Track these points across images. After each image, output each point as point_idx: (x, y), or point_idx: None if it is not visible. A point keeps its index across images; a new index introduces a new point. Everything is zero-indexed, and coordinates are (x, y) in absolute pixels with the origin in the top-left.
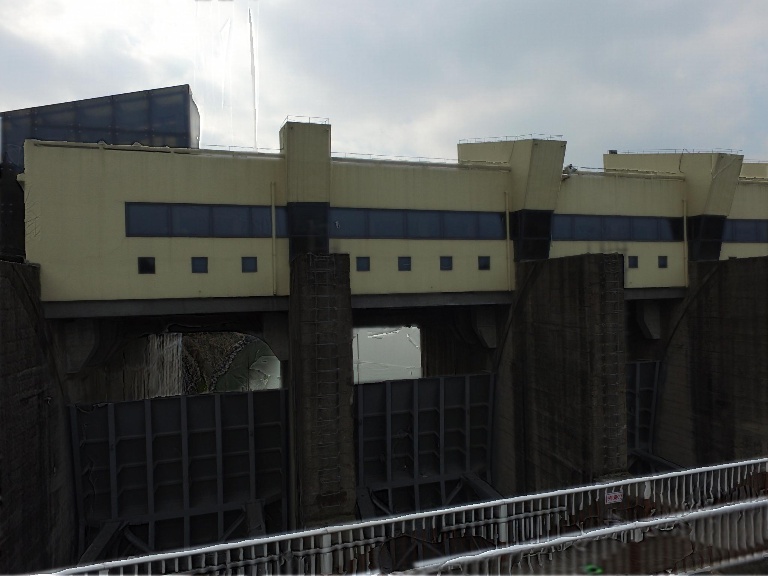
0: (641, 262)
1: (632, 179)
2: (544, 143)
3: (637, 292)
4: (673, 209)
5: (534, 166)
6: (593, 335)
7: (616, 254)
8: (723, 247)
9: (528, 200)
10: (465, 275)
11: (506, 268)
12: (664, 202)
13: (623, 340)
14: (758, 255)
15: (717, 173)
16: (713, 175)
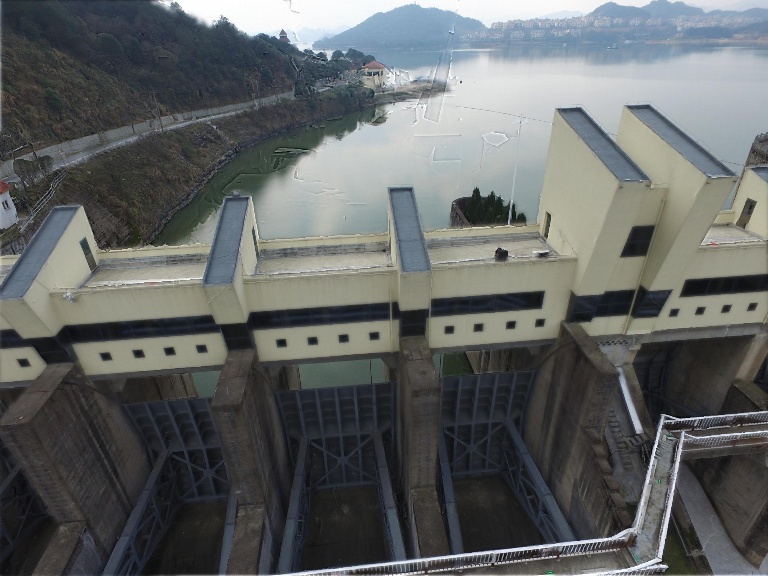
0: (178, 351)
1: (151, 291)
2: (2, 303)
3: (184, 369)
4: (205, 309)
5: (7, 316)
6: (22, 465)
7: (17, 426)
8: (269, 333)
9: (22, 334)
10: (11, 371)
11: (46, 365)
12: (193, 305)
13: (51, 466)
14: (312, 336)
15: (210, 300)
16: (206, 301)
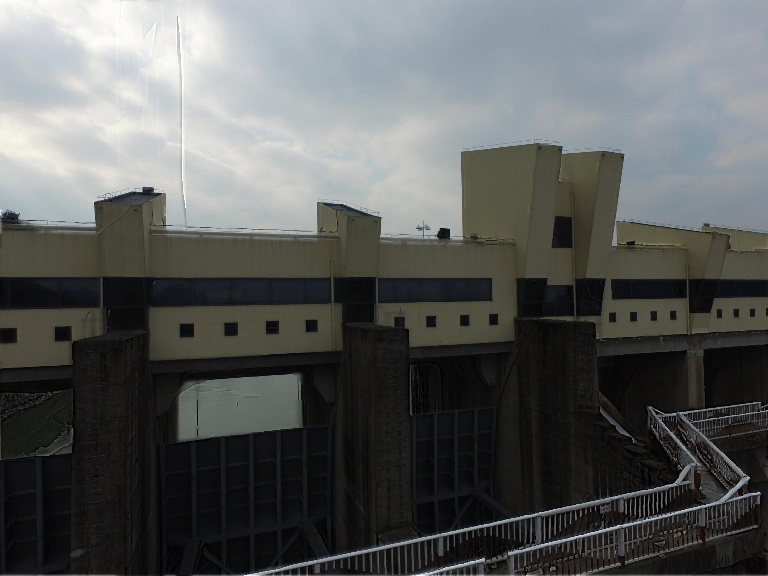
0: (24, 335)
1: (11, 231)
2: None
3: (21, 372)
4: (85, 268)
5: None
6: None
7: None
8: (171, 312)
9: None
10: None
11: None
12: (69, 259)
13: None
14: (231, 320)
15: (103, 227)
16: (97, 229)
